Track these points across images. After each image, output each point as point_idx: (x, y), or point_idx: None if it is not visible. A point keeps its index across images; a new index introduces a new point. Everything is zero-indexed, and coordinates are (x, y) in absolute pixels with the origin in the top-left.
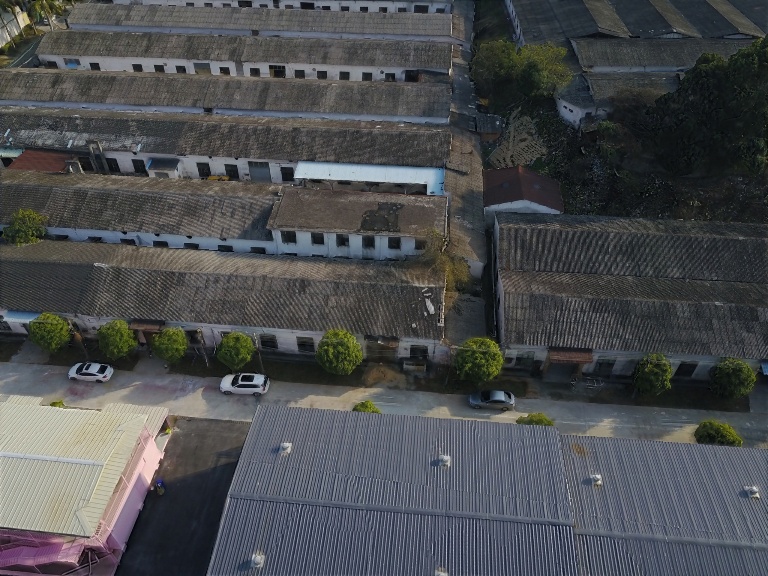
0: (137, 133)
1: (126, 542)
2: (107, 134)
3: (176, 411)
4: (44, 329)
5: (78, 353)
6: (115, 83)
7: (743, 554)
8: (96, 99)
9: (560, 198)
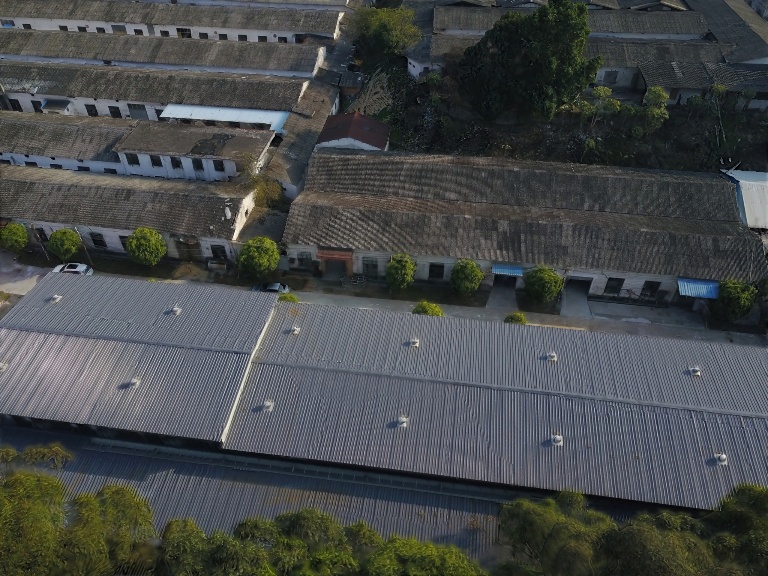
0: (36, 78)
1: None
2: (11, 78)
3: (12, 290)
4: None
5: None
6: (31, 38)
7: (380, 380)
8: (13, 51)
9: (386, 139)
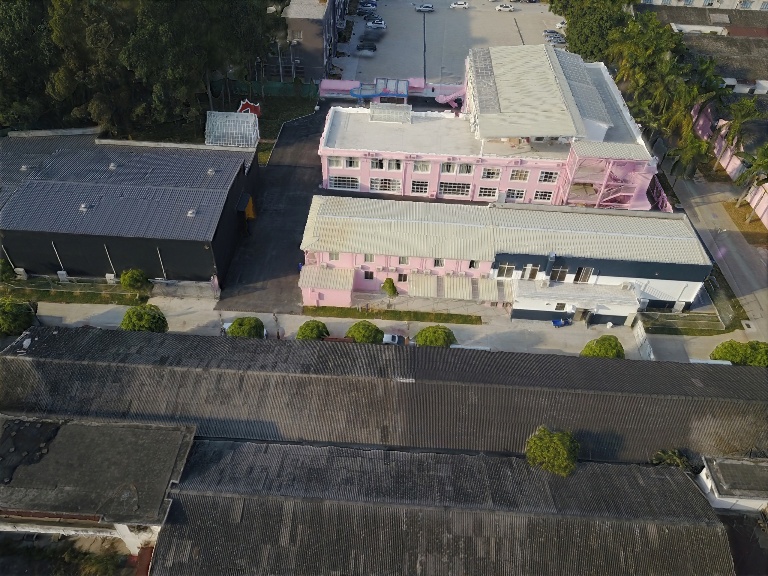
0: None
1: None
2: None
3: (305, 318)
4: None
5: None
6: None
7: None
8: None
9: None
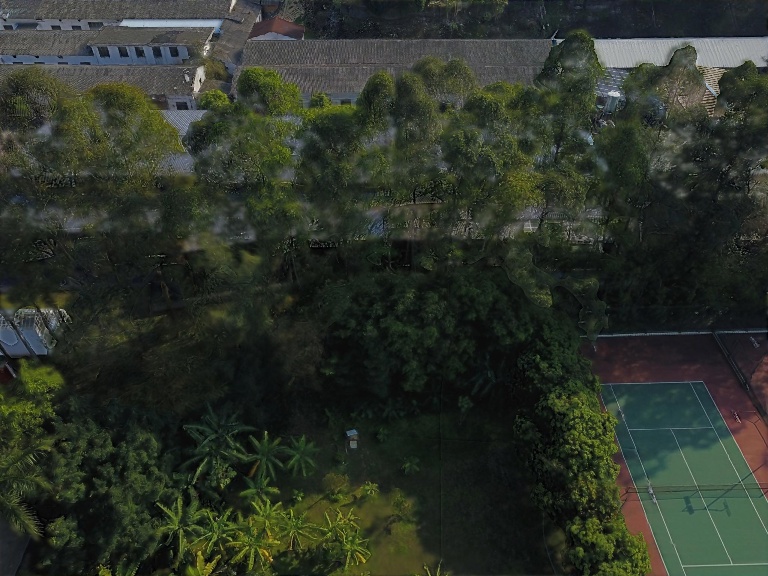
0: (6, 7)
1: None
2: None
3: None
4: None
5: None
6: None
7: None
8: None
9: (302, 34)
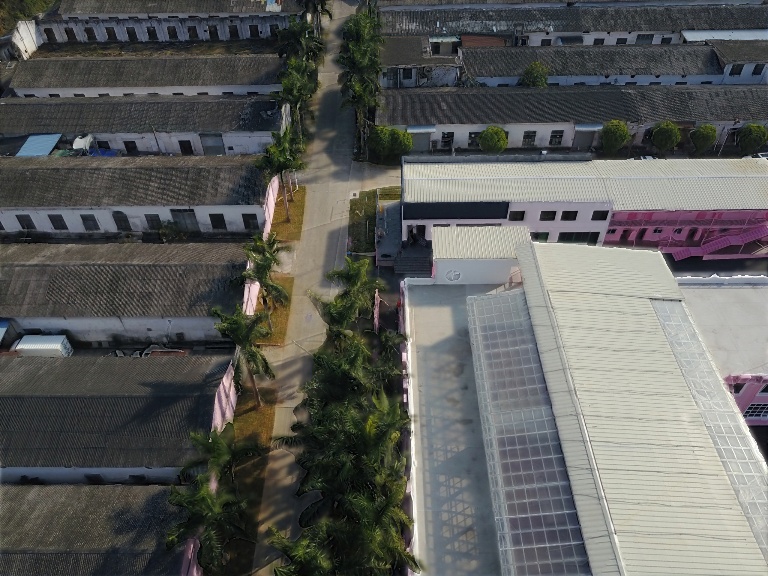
0: (544, 19)
1: None
2: (520, 21)
3: None
4: (620, 129)
5: (618, 155)
6: None
7: None
8: (478, 1)
9: None
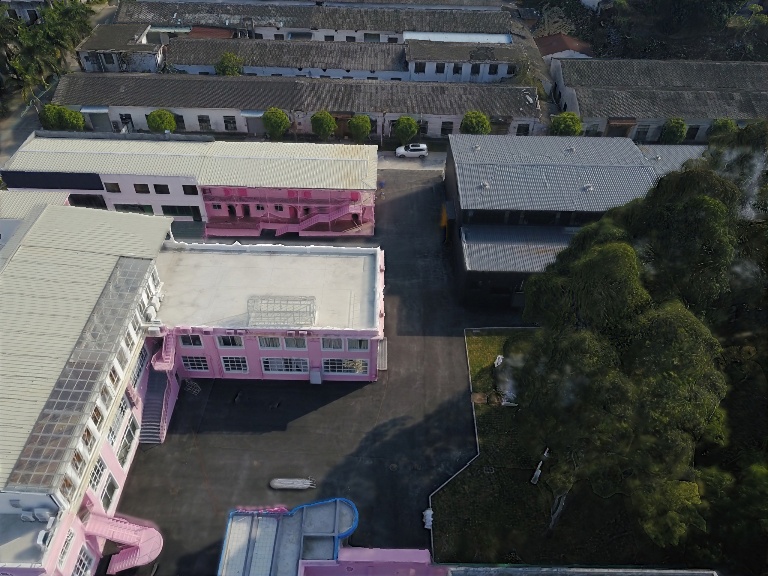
0: (277, 15)
1: (374, 219)
2: (254, 16)
3: None
4: (276, 116)
5: (288, 142)
6: None
7: None
8: None
9: (592, 52)
